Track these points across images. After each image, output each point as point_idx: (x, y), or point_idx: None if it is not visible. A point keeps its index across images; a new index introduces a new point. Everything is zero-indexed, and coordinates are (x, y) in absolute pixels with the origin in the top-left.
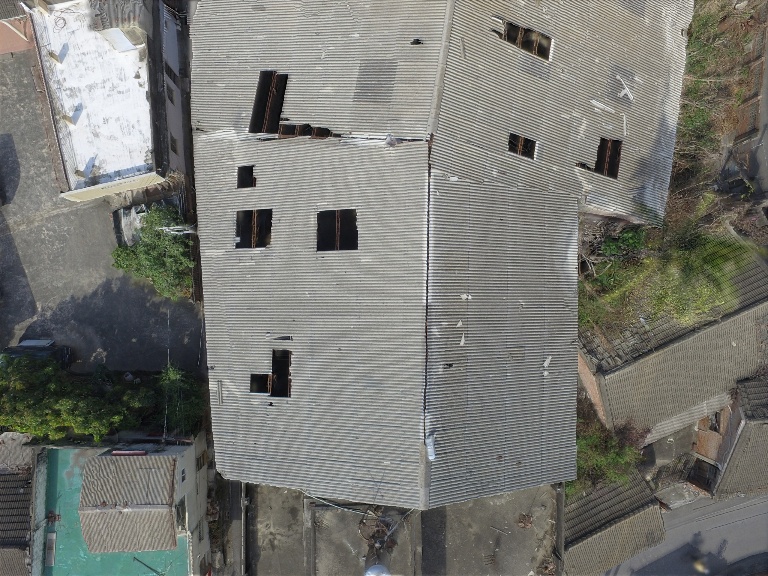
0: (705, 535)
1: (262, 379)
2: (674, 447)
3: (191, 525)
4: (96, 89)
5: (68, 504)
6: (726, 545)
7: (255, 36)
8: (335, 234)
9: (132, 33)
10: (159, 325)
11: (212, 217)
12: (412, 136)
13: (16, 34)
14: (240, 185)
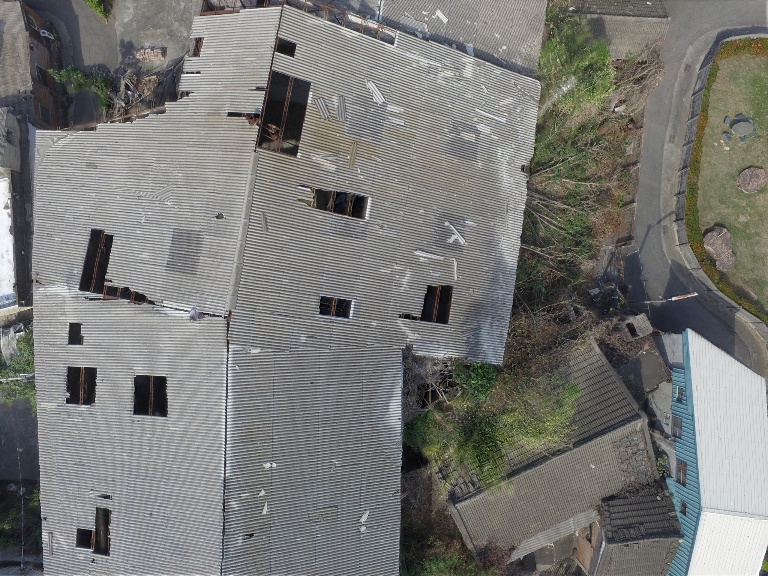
0: None
1: (86, 535)
2: (555, 552)
3: None
4: None
5: None
6: None
7: (88, 193)
8: (149, 399)
9: None
10: None
11: (47, 370)
12: (213, 311)
13: None
14: (70, 341)
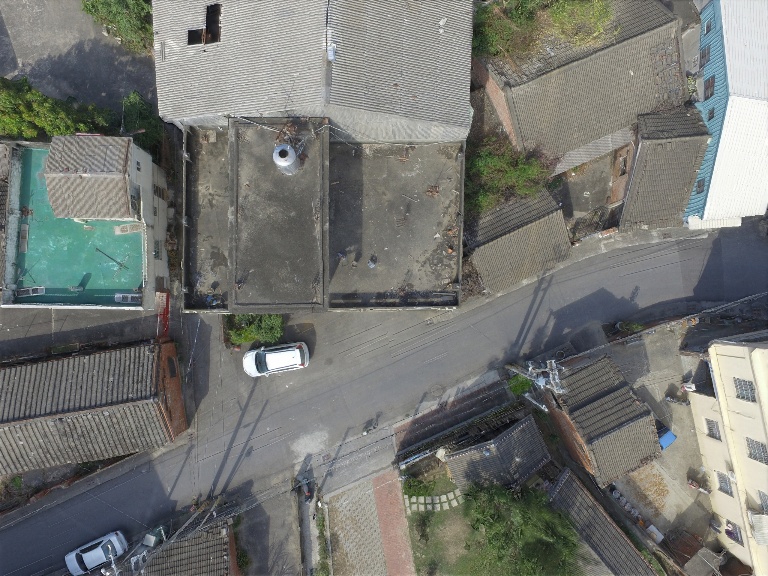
0: (618, 281)
1: (198, 33)
2: (590, 200)
3: (146, 217)
4: None
5: (40, 201)
6: (638, 291)
7: None
8: None
9: None
10: (126, 81)
11: None
12: None
13: None
14: None
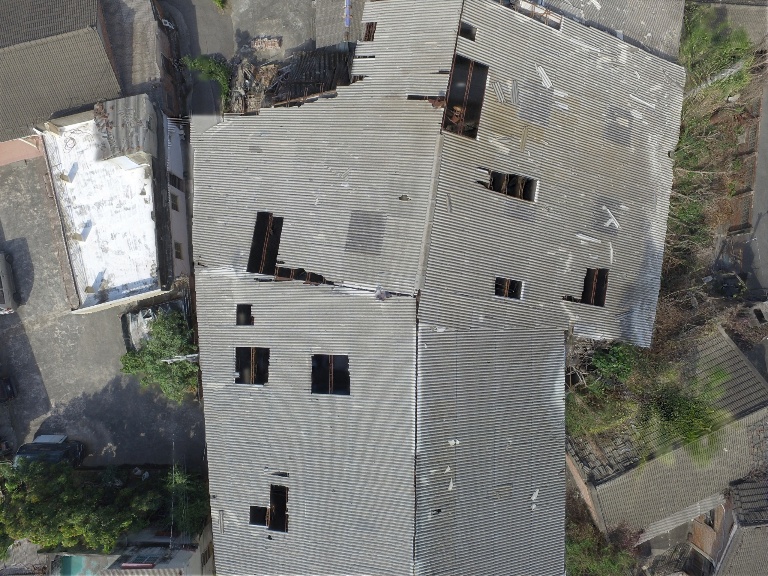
0: None
1: (261, 512)
2: (669, 537)
3: None
4: (104, 206)
5: None
6: None
7: (252, 177)
8: (329, 378)
9: (137, 157)
10: (166, 420)
11: (213, 351)
12: (401, 291)
13: (29, 145)
14: (239, 322)
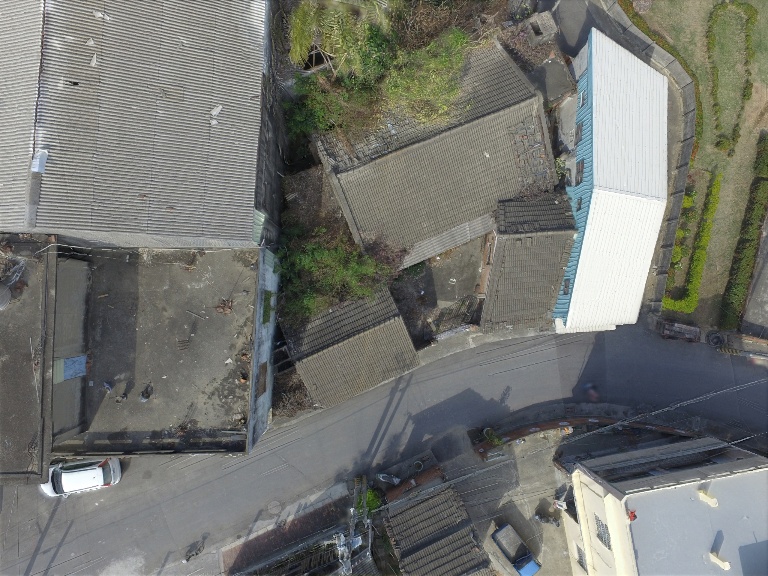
0: (488, 380)
1: None
2: (457, 288)
3: None
4: None
5: None
6: (509, 391)
7: None
8: None
9: None
10: None
11: None
12: None
13: None
14: None
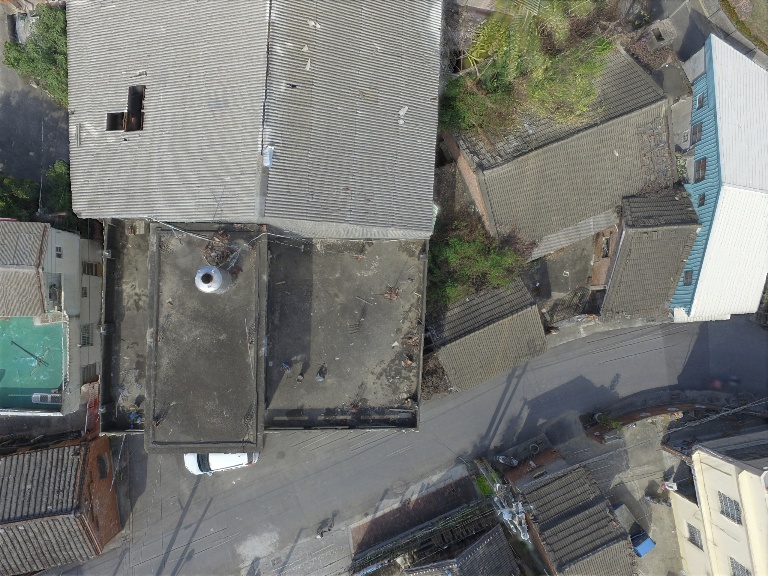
0: (598, 368)
1: (118, 117)
2: (570, 280)
3: (69, 308)
4: None
5: None
6: (619, 379)
7: None
8: None
9: None
10: (57, 139)
11: None
12: None
13: None
14: None
